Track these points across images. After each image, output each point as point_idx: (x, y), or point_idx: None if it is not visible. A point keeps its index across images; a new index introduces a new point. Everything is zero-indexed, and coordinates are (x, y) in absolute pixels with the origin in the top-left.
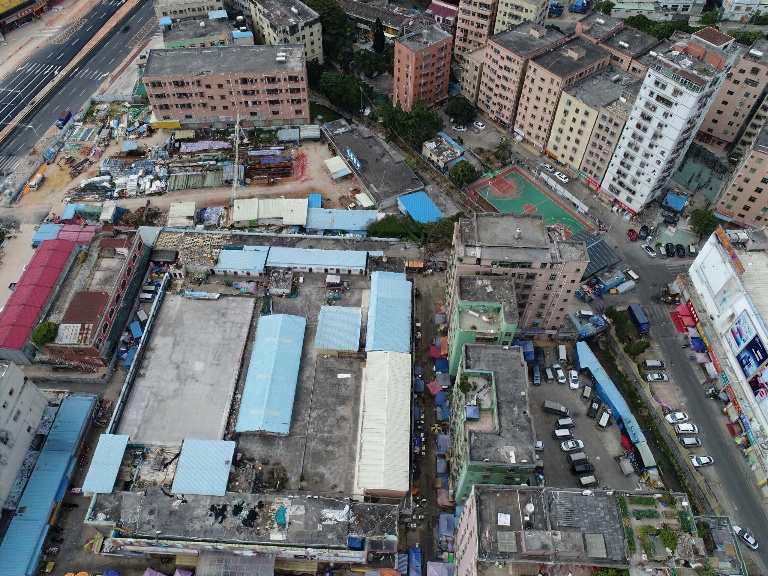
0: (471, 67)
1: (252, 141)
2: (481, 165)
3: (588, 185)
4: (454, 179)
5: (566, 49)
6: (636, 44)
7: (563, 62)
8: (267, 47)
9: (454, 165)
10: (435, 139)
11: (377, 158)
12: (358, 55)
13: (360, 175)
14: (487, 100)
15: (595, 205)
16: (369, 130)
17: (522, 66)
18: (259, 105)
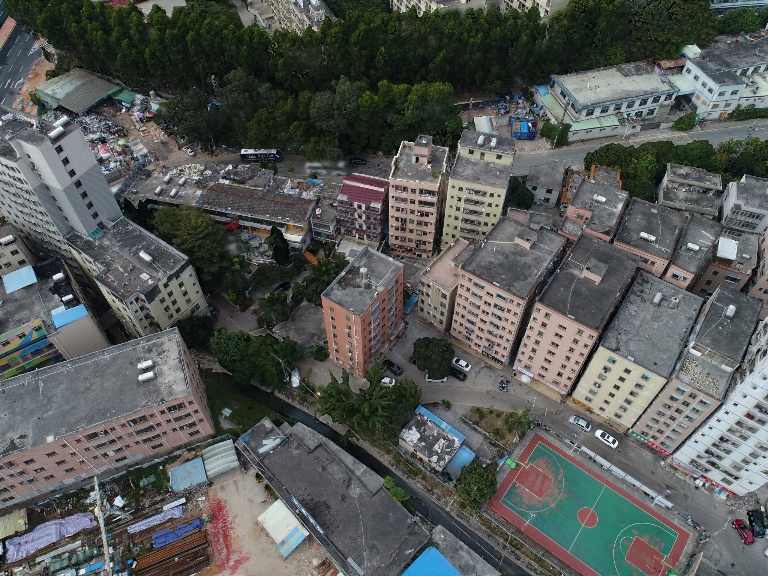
0: (435, 293)
1: (129, 500)
2: (490, 444)
3: (646, 443)
4: (467, 500)
5: (575, 262)
6: (660, 229)
7: (582, 292)
8: (117, 348)
9: (461, 475)
10: (414, 420)
11: (342, 495)
12: (261, 299)
13: (325, 541)
14: (467, 332)
15: (670, 481)
16: (312, 430)
17: (524, 307)
18: (127, 449)
